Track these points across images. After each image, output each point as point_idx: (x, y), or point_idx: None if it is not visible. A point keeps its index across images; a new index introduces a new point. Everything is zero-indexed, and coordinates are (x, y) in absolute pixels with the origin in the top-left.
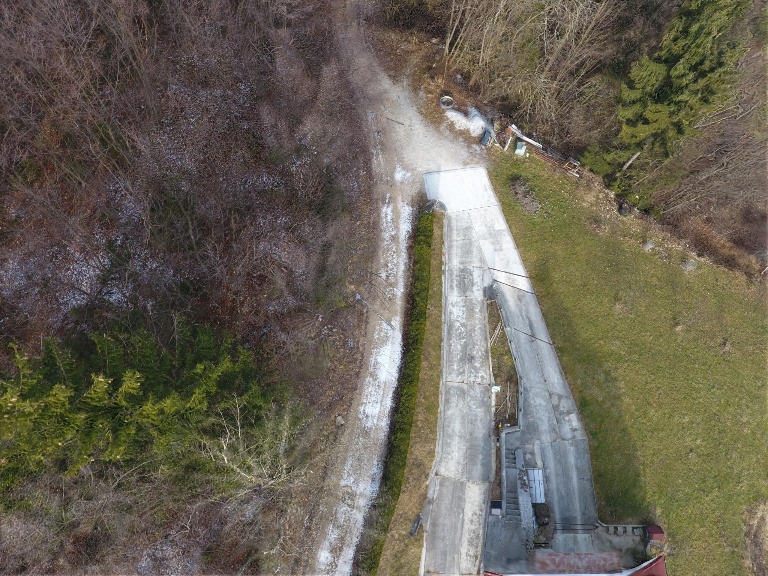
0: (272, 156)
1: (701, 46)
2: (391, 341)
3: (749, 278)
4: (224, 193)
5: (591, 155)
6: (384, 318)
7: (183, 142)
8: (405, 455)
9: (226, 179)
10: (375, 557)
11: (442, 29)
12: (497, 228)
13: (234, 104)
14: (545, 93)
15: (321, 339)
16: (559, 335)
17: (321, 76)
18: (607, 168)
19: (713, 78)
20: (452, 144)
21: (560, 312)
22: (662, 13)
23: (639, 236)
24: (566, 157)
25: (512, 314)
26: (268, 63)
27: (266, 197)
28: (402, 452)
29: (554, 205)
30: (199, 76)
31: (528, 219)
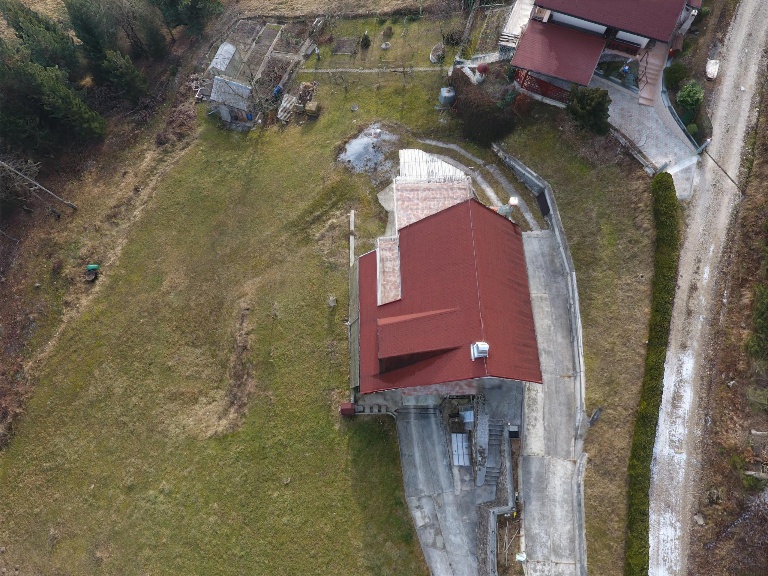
0: None
1: None
2: None
3: None
4: None
5: None
6: None
7: None
8: (637, 487)
9: None
10: (653, 396)
11: None
12: None
13: None
14: None
15: None
16: None
17: None
18: None
19: None
20: None
21: None
22: None
23: None
24: None
25: None
26: None
27: None
28: (641, 490)
29: None
30: None
31: None
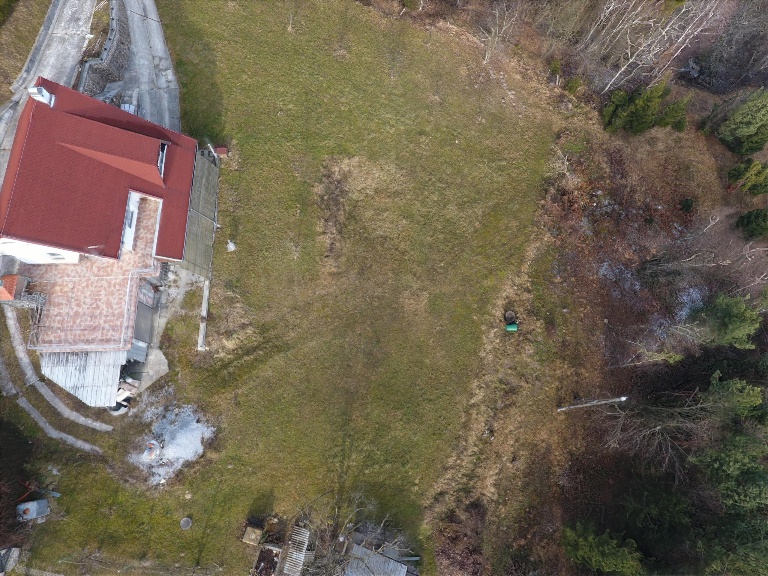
0: None
1: None
2: None
3: (385, 15)
4: None
5: None
6: None
7: None
8: None
9: None
10: None
11: None
12: None
13: None
14: None
15: None
16: (167, 15)
17: None
18: None
19: None
20: None
21: None
22: None
23: None
24: None
25: (130, 0)
26: None
27: None
28: None
29: None
30: None
31: None
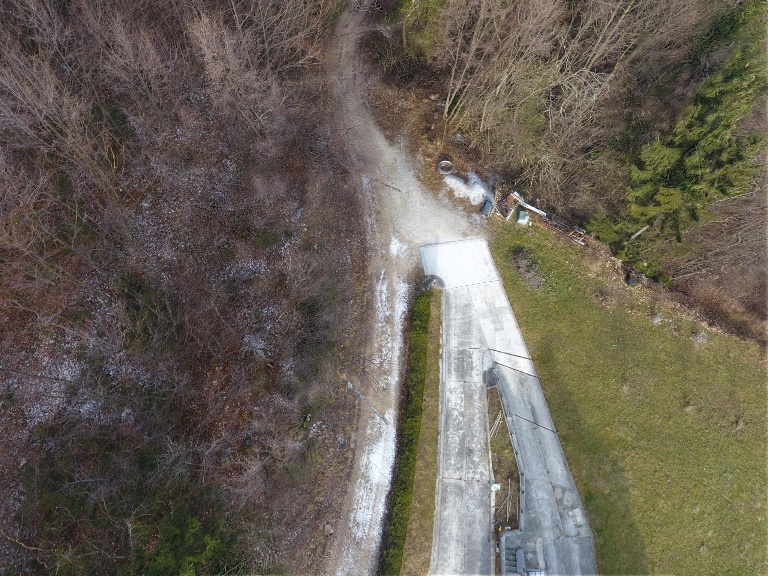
0: (259, 239)
1: (719, 137)
2: (384, 437)
3: (762, 347)
4: (206, 284)
5: (597, 222)
6: (377, 411)
7: (163, 228)
8: (398, 574)
9: (209, 268)
10: None
11: (441, 85)
12: (498, 305)
13: (219, 183)
14: (549, 164)
15: (309, 440)
16: (563, 422)
17: (314, 136)
18: (614, 236)
19: (731, 168)
20: (451, 213)
21: (564, 397)
22: (672, 69)
23: (647, 307)
24: (571, 224)
25: (513, 399)
26: (257, 131)
27: (252, 286)
28: (394, 571)
29: (558, 278)
30: (182, 153)
31: (531, 295)
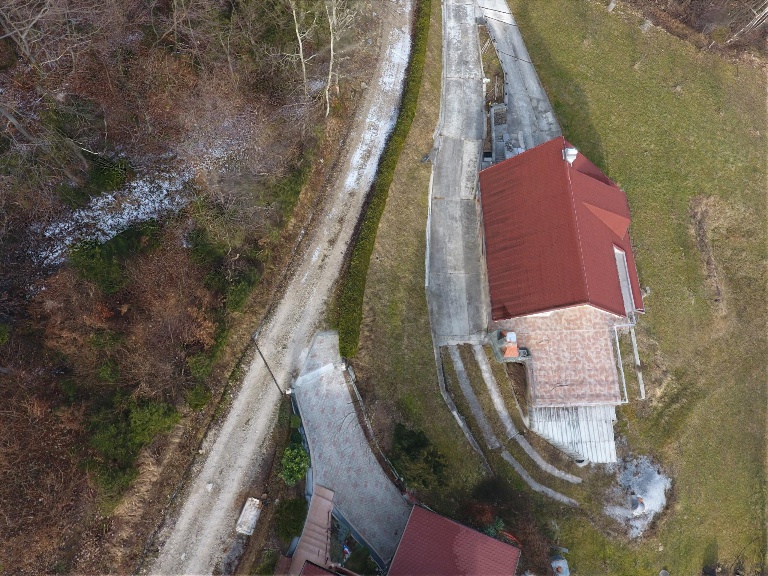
0: None
1: None
2: (402, 40)
3: (698, 48)
4: None
5: None
6: (396, 26)
7: None
8: (416, 96)
9: None
10: (395, 149)
11: None
12: None
13: None
14: None
15: None
16: (537, 56)
17: None
18: None
19: None
20: None
21: (538, 40)
22: None
23: (604, 1)
24: None
25: (499, 41)
26: None
27: None
28: (414, 93)
29: None
30: None
31: None
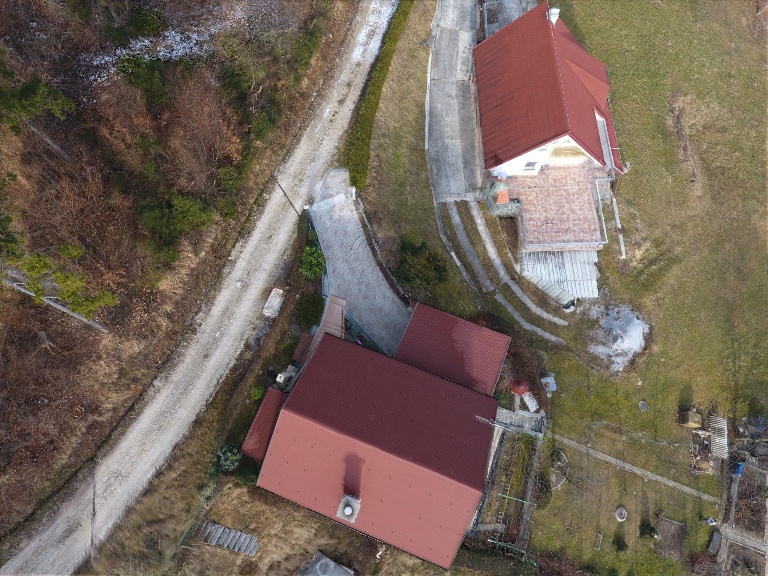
0: None
1: None
2: None
3: None
4: None
5: None
6: None
7: None
8: None
9: None
10: (397, 24)
11: None
12: None
13: None
14: None
15: None
16: None
17: None
18: None
19: None
20: None
21: None
22: None
23: None
24: None
25: None
26: None
27: None
28: None
29: None
30: None
31: None
